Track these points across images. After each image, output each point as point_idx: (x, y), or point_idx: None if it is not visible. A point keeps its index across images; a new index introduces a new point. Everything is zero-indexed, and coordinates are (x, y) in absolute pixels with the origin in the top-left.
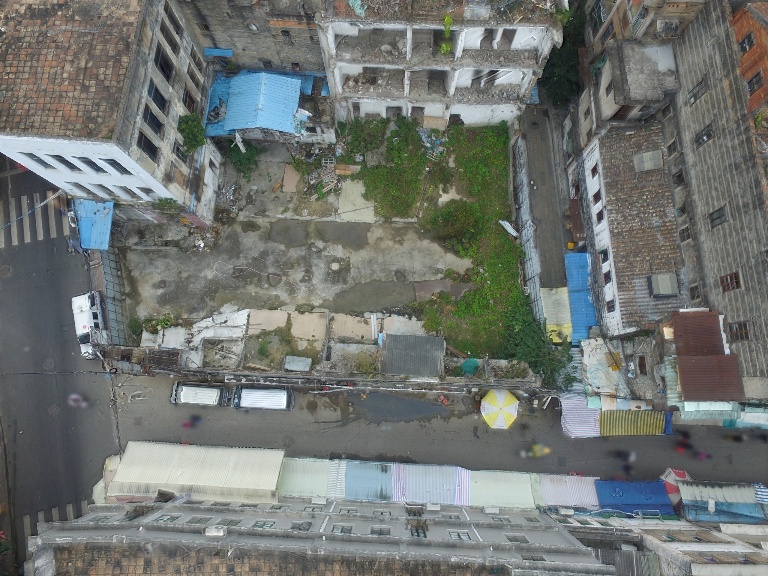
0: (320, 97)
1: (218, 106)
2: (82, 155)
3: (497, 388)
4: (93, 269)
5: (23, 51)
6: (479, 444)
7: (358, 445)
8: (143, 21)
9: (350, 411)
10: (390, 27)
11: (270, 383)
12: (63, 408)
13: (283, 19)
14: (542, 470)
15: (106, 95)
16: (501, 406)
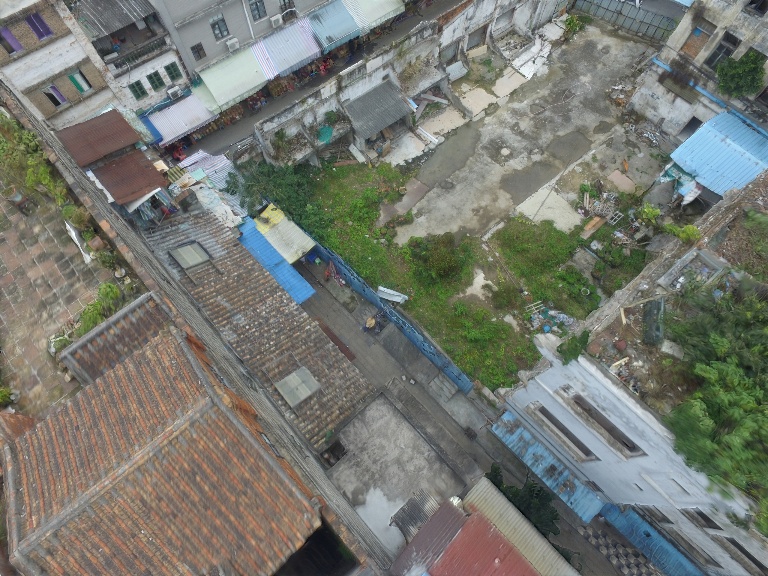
0: None
1: None
2: None
3: None
4: None
5: None
6: None
7: None
8: None
9: None
10: None
11: None
12: None
13: None
14: (211, 144)
15: None
16: None
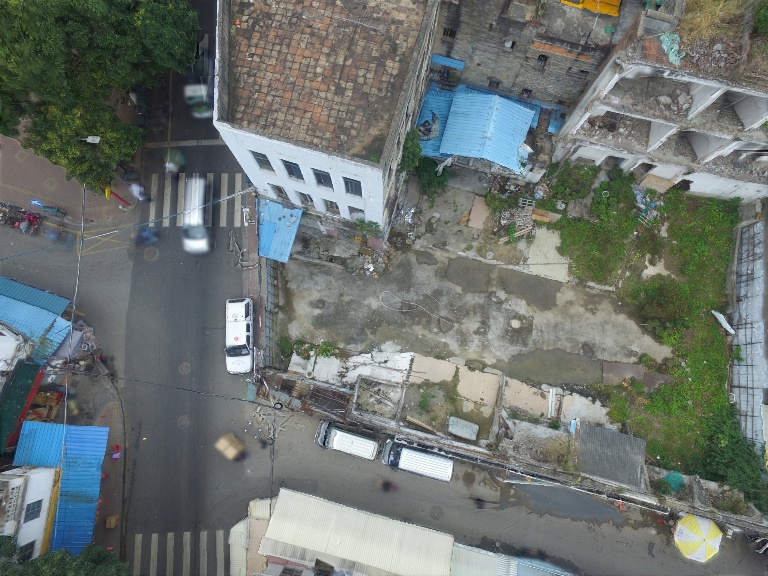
0: (545, 133)
1: (430, 121)
2: (325, 169)
3: None
4: (246, 271)
5: (272, 31)
6: (653, 564)
7: (515, 535)
8: (427, 24)
9: (511, 494)
10: (702, 83)
11: (445, 454)
12: (194, 421)
13: (554, 43)
14: None
15: (364, 103)
16: (705, 536)
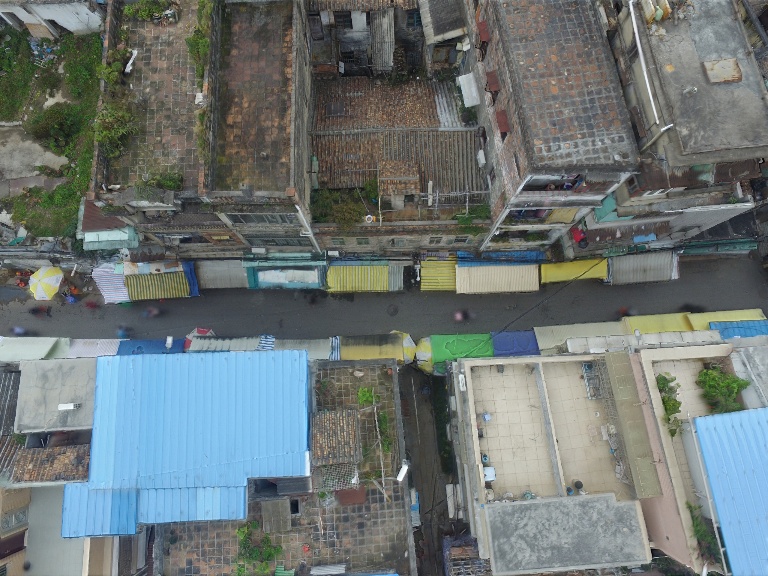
0: None
1: None
2: None
3: (23, 258)
4: None
5: None
6: (51, 322)
7: None
8: None
9: None
10: None
11: None
12: None
13: None
14: None
15: None
16: (40, 278)
